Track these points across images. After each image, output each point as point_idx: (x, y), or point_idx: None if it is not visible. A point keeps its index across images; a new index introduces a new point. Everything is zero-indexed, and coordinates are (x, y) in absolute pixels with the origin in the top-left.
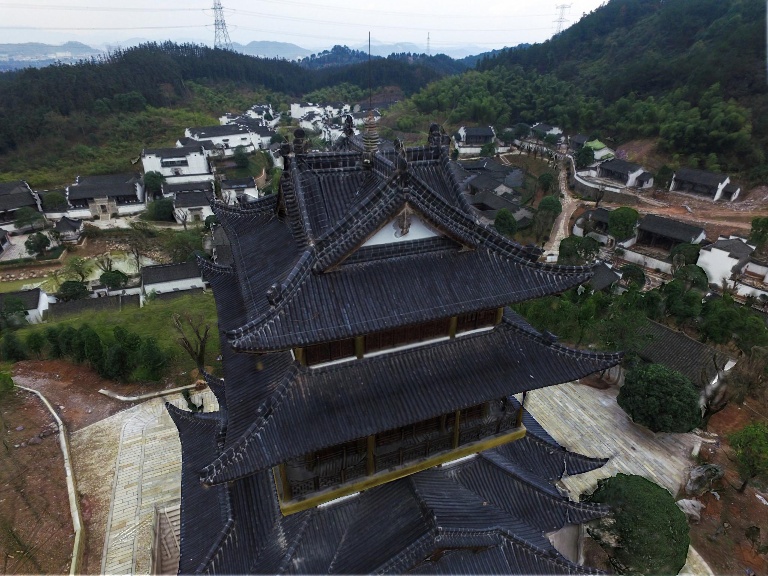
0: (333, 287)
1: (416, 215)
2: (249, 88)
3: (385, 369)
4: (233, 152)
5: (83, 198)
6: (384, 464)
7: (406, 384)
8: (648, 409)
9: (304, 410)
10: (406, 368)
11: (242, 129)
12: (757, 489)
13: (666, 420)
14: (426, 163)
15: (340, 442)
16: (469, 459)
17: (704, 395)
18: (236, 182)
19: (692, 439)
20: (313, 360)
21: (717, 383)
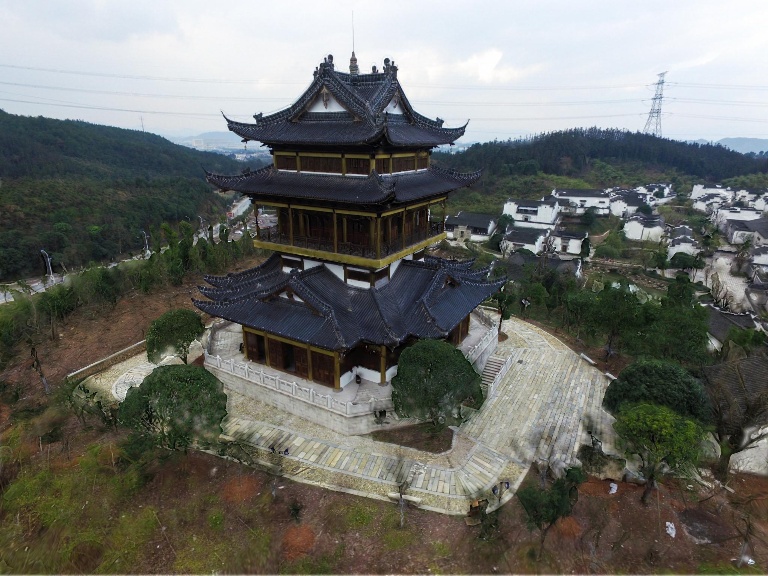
0: (291, 127)
1: (329, 94)
2: (658, 169)
3: (304, 179)
4: (584, 211)
5: (453, 224)
6: (299, 242)
7: (303, 185)
8: (616, 392)
9: (262, 181)
10: (312, 181)
11: (604, 194)
12: (686, 527)
13: (620, 404)
14: (382, 83)
15: (258, 192)
16: (365, 289)
17: (718, 420)
18: (569, 234)
19: (683, 471)
20: (280, 166)
21: (743, 412)
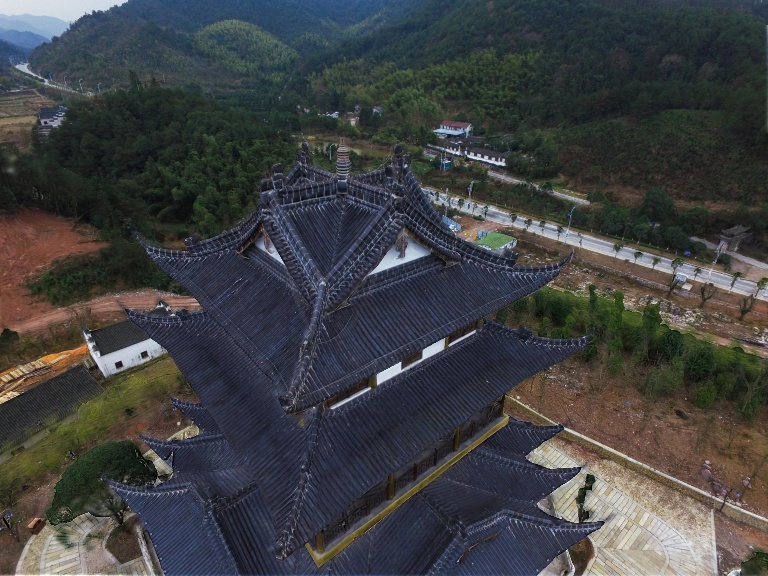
0: None
1: None
2: None
3: None
4: None
5: None
6: None
7: None
8: None
9: None
10: None
11: None
12: None
13: None
14: None
15: None
16: None
17: None
18: None
19: None
20: None
21: None
